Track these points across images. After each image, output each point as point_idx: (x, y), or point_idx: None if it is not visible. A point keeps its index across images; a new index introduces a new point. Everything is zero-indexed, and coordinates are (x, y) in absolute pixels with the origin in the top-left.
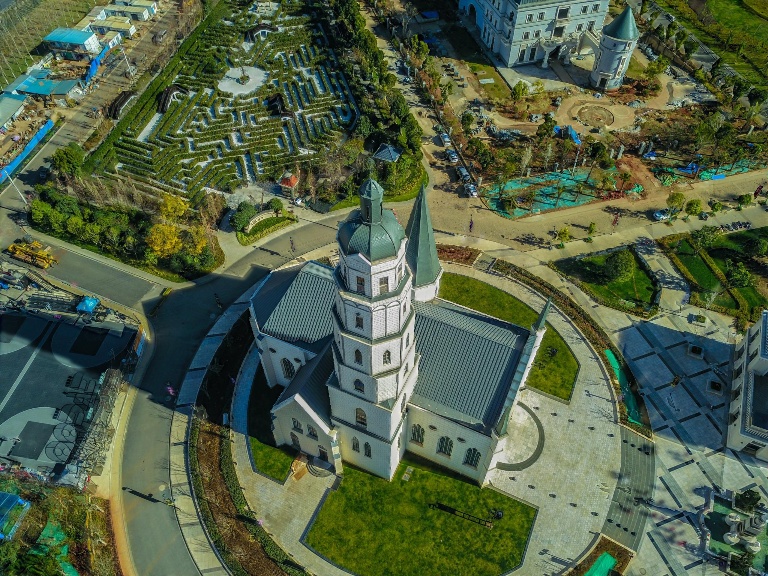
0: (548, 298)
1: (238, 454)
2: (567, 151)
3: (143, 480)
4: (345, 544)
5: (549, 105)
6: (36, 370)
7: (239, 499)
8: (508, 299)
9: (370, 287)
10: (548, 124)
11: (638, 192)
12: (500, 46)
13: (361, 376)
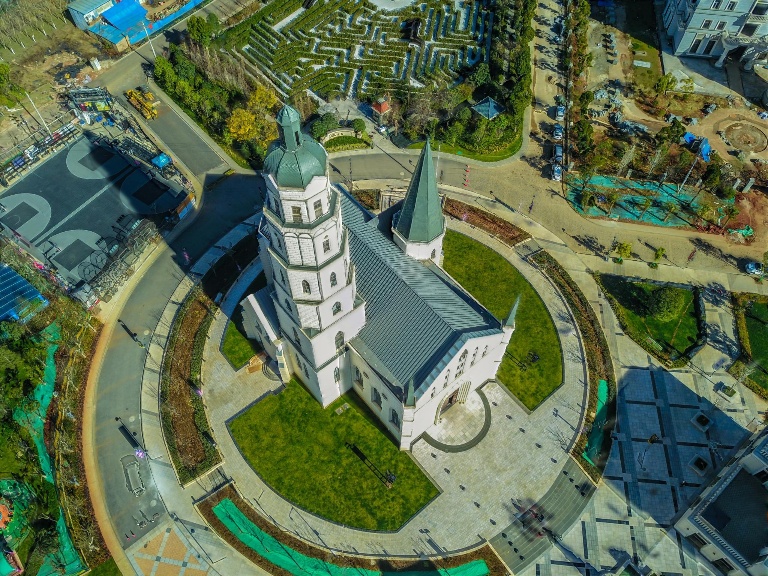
0: (571, 306)
1: (215, 331)
2: (683, 164)
3: (136, 320)
4: (258, 442)
5: (698, 110)
6: (102, 200)
7: (196, 367)
8: (529, 292)
9: (282, 211)
10: (674, 128)
11: (744, 235)
12: (676, 29)
13: (287, 296)
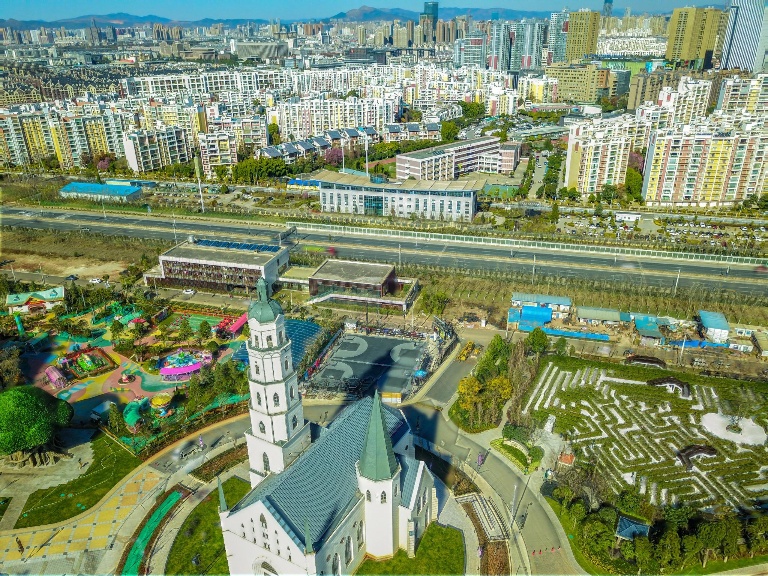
0: None
1: None
2: None
3: None
4: None
5: None
6: (378, 368)
7: None
8: None
9: None
10: None
11: None
12: None
13: None
